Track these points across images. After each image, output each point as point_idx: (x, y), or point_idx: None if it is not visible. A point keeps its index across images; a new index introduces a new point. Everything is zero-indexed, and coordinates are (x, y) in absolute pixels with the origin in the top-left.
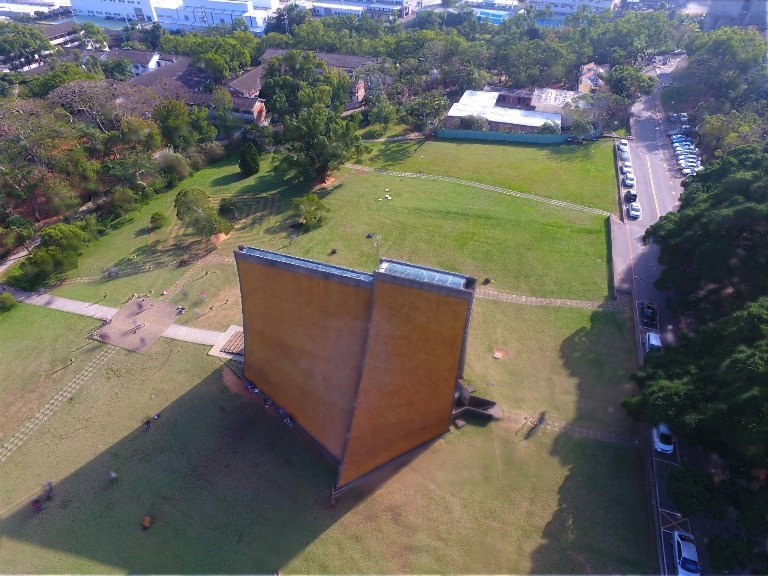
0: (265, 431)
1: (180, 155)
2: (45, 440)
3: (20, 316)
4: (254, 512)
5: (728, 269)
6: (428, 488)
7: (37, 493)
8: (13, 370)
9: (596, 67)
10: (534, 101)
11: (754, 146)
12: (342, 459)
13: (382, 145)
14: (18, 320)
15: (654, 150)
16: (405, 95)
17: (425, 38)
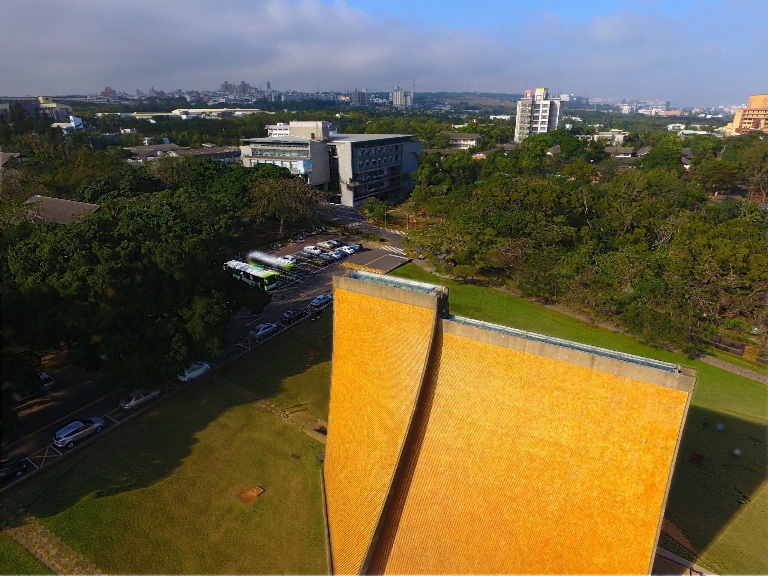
0: None
1: None
2: None
3: None
4: None
5: None
6: None
7: None
8: None
9: None
10: None
11: None
12: None
13: None
14: None
15: None
16: None
17: None
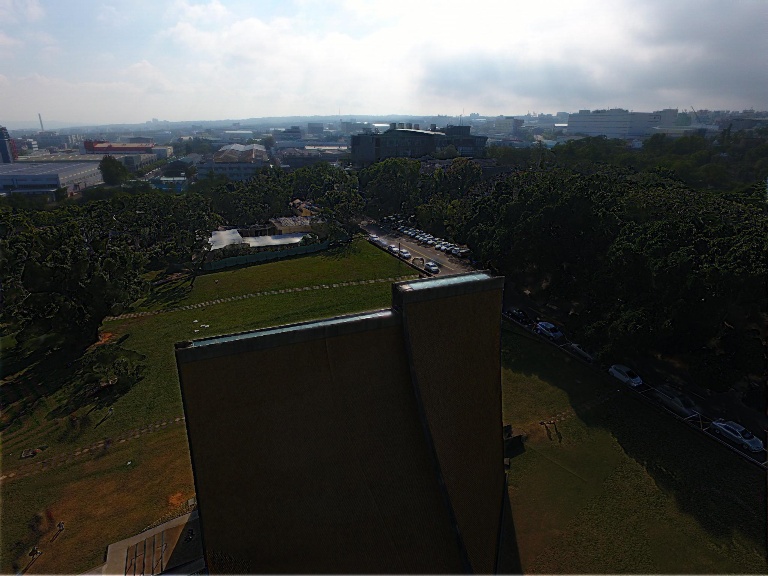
0: None
1: None
2: None
3: None
4: None
5: (563, 250)
6: (556, 536)
7: None
8: None
9: (302, 202)
10: (278, 226)
11: (487, 197)
12: (470, 569)
13: None
14: None
15: (395, 238)
16: (137, 246)
17: (125, 199)
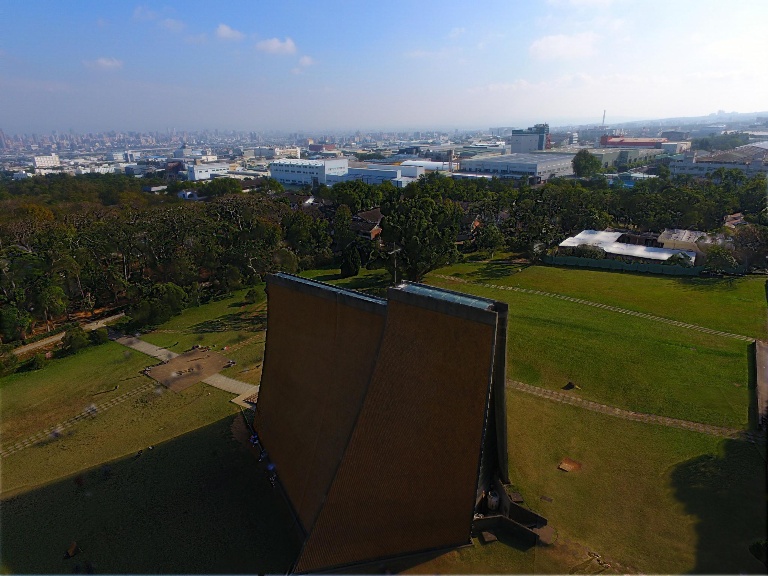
0: (244, 485)
1: (293, 253)
2: (48, 447)
3: (104, 349)
4: (183, 573)
5: None
6: None
7: (6, 492)
8: (68, 386)
9: None
10: (662, 238)
11: None
12: (309, 532)
13: (484, 265)
14: (100, 352)
15: None
16: None
17: None
